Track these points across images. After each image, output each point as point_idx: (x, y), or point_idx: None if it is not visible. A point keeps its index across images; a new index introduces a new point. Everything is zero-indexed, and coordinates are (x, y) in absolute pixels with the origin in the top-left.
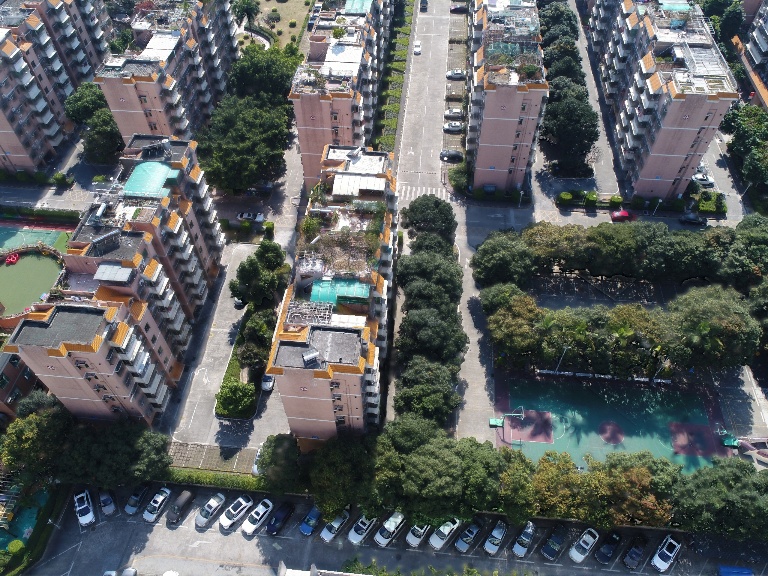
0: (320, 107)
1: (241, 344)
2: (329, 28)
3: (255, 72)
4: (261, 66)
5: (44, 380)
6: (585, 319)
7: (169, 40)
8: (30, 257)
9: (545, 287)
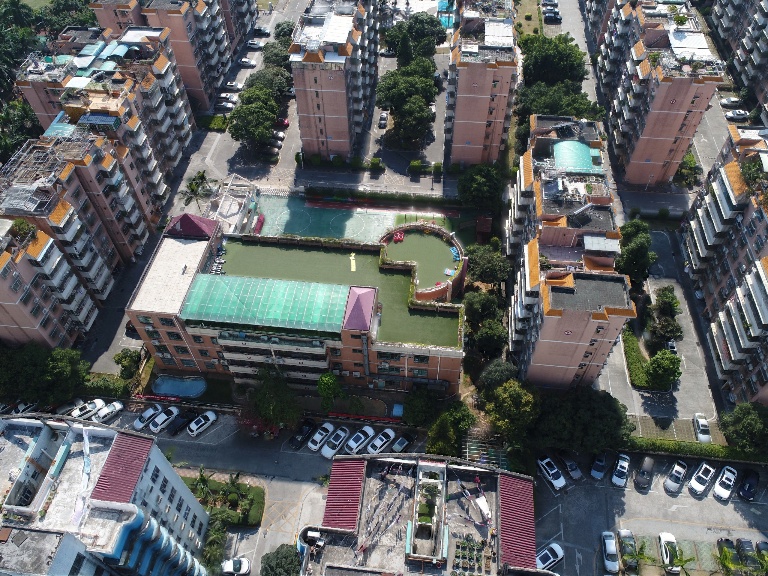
0: (686, 91)
1: None
2: (657, 16)
3: (559, 60)
4: (564, 54)
5: (541, 346)
6: None
7: (504, 28)
8: (414, 235)
9: None
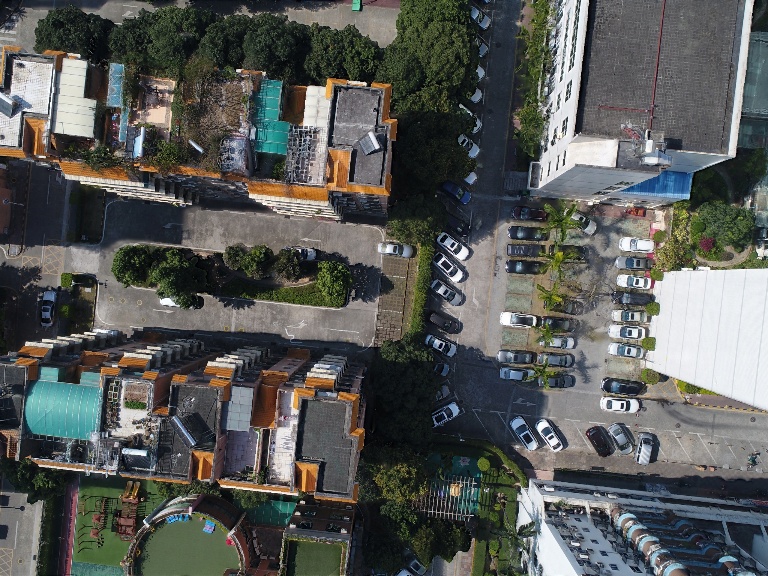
0: None
1: (256, 291)
2: None
3: None
4: None
5: None
6: None
7: None
8: (144, 570)
9: None
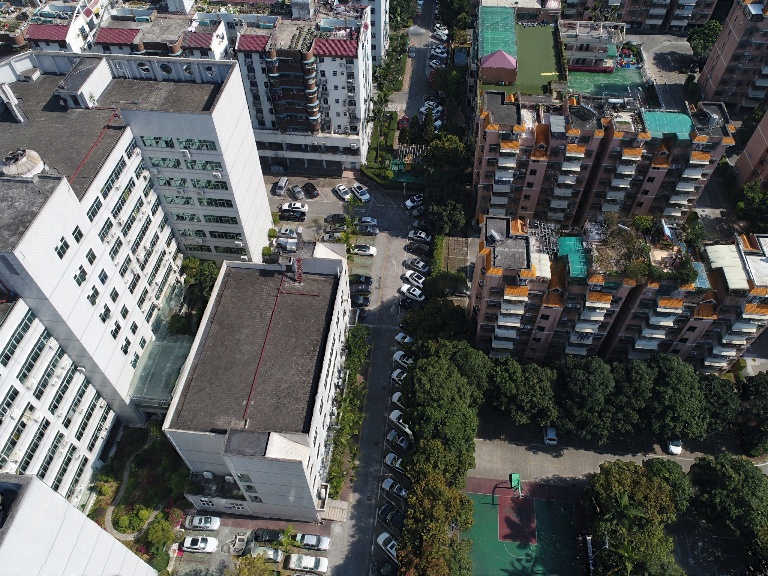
0: None
1: None
2: None
3: None
4: None
5: None
6: (652, 568)
7: None
8: None
9: (731, 574)
